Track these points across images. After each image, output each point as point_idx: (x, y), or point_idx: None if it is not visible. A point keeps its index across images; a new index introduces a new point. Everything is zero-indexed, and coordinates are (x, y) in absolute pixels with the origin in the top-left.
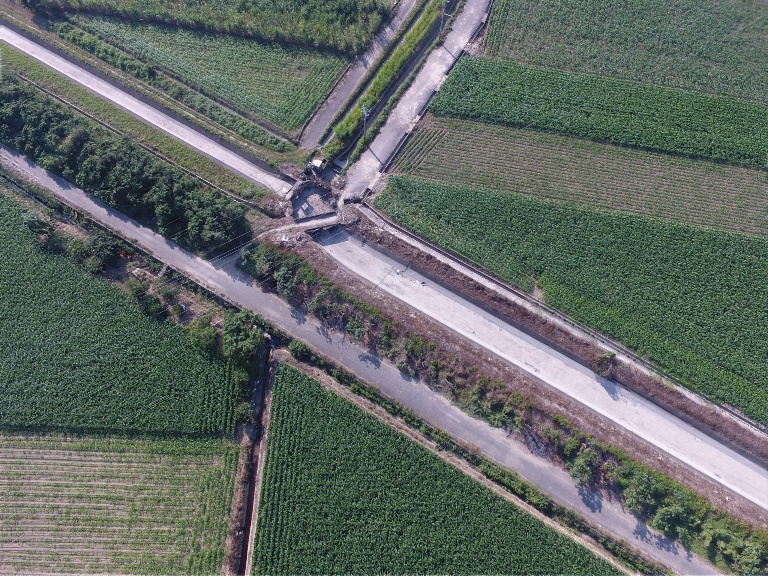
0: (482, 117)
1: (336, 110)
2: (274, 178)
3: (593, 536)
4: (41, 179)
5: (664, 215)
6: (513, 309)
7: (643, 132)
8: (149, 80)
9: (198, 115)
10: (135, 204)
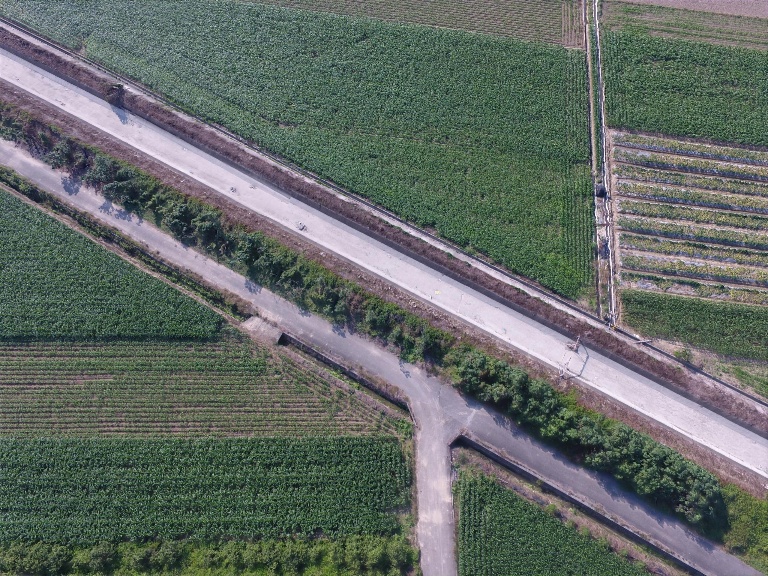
0: None
1: None
2: None
3: (69, 214)
4: None
5: None
6: (50, 59)
7: None
8: None
9: None
10: None
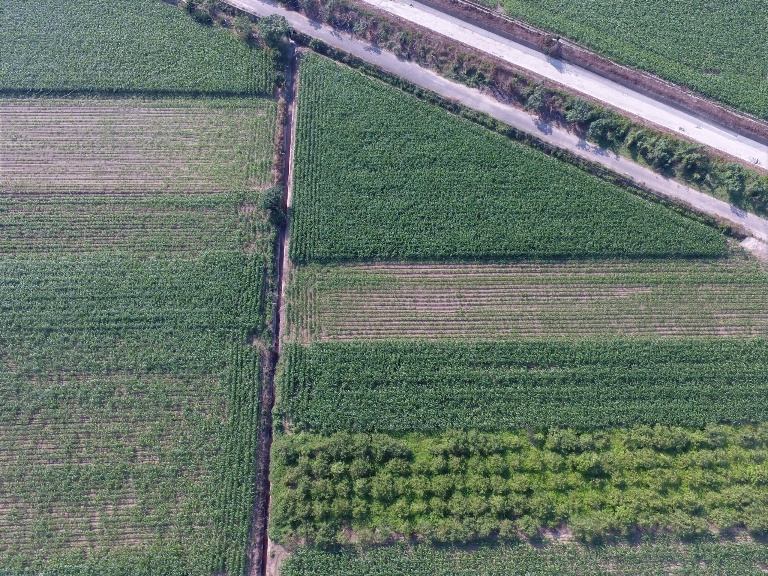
0: None
1: None
2: None
3: (547, 152)
4: None
5: None
6: (481, 15)
7: None
8: None
9: None
10: None
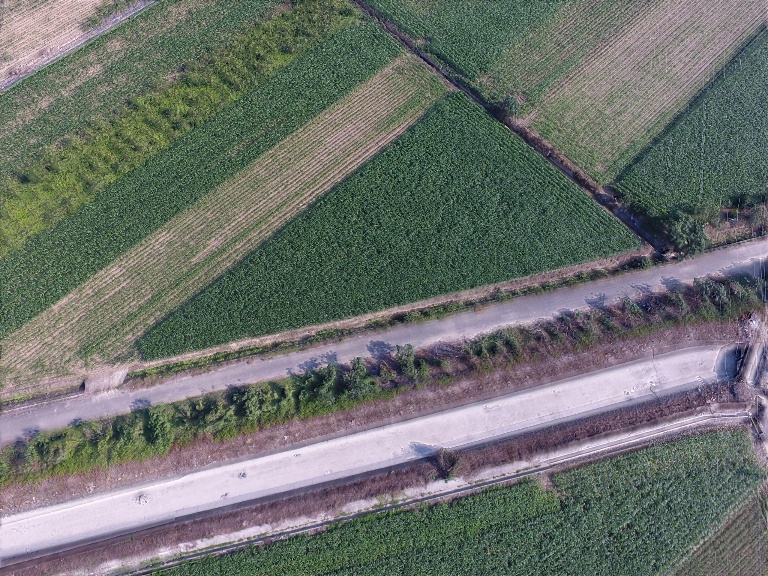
0: None
1: None
2: None
3: None
4: None
5: None
6: (551, 438)
7: None
8: None
9: None
10: None
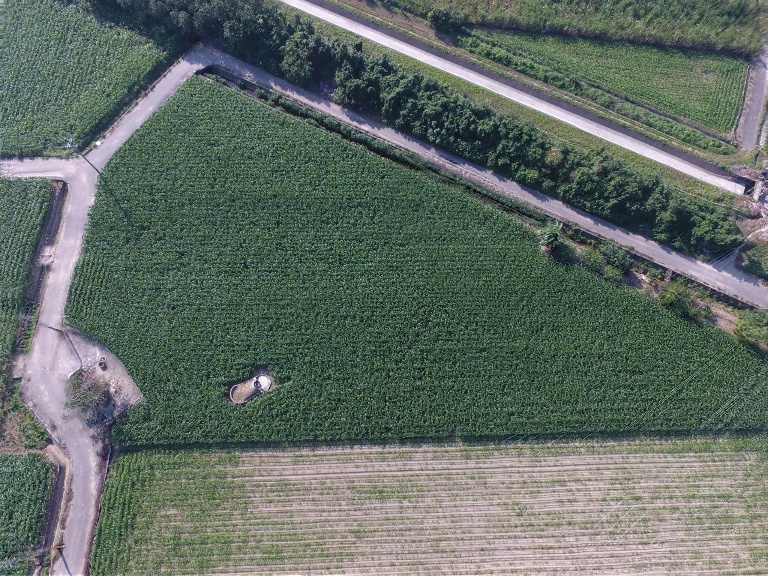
0: None
1: (759, 111)
2: (724, 180)
3: None
4: (517, 193)
5: None
6: None
7: None
8: (576, 91)
9: (634, 122)
10: (633, 212)
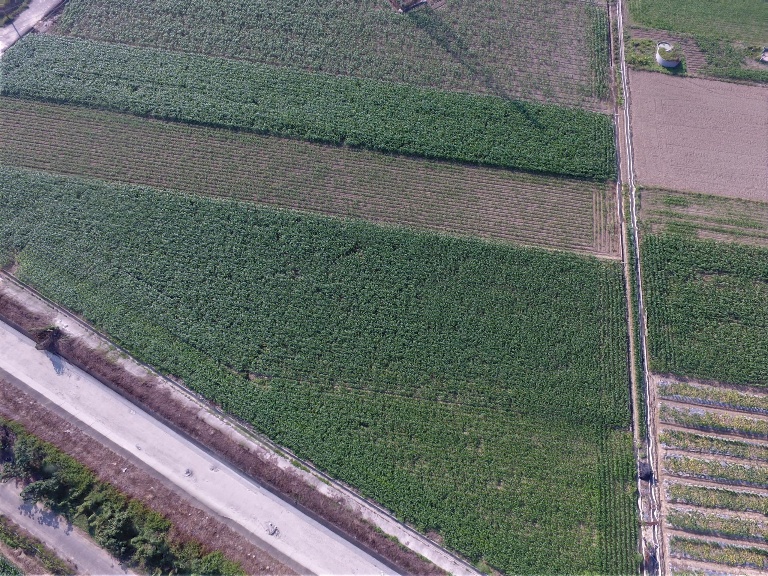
0: (21, 93)
1: None
2: None
3: None
4: None
5: (181, 187)
6: None
7: (185, 104)
8: None
9: None
10: None
